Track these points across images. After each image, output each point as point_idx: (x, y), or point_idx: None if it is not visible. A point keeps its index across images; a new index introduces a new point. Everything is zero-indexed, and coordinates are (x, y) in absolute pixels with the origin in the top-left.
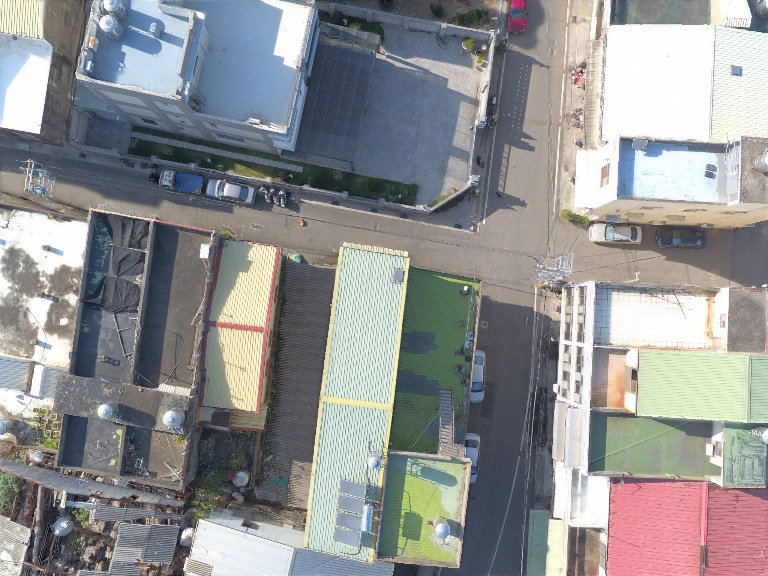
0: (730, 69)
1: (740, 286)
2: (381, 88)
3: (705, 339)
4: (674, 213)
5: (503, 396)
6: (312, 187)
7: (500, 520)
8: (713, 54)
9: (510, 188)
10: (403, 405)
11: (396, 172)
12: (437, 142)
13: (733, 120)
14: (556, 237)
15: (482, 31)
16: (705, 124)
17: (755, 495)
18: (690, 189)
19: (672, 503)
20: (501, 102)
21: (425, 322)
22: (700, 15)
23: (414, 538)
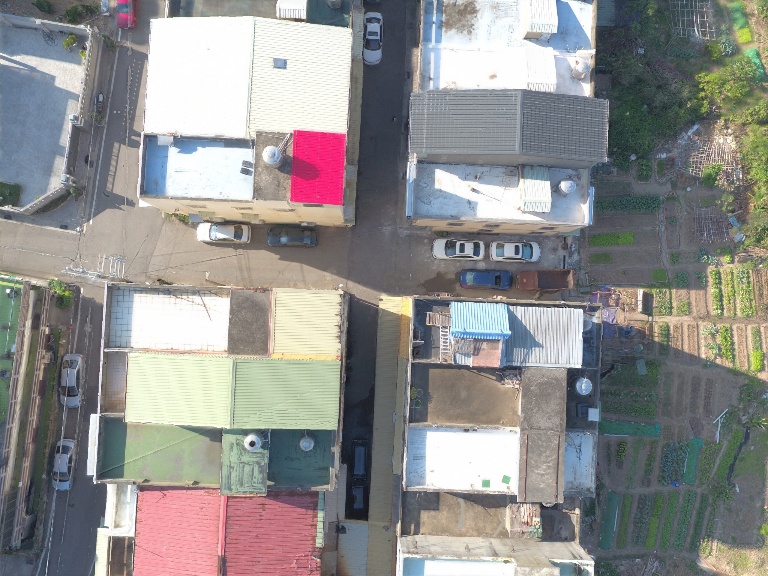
0: (272, 62)
1: (358, 286)
2: None
3: None
4: (240, 211)
5: None
6: None
7: None
8: (252, 47)
9: (118, 187)
10: None
11: None
12: (43, 141)
13: (275, 115)
14: (164, 237)
15: (78, 27)
16: (242, 119)
17: (286, 503)
18: (225, 186)
19: (193, 511)
20: (112, 99)
21: None
22: (270, 7)
23: None
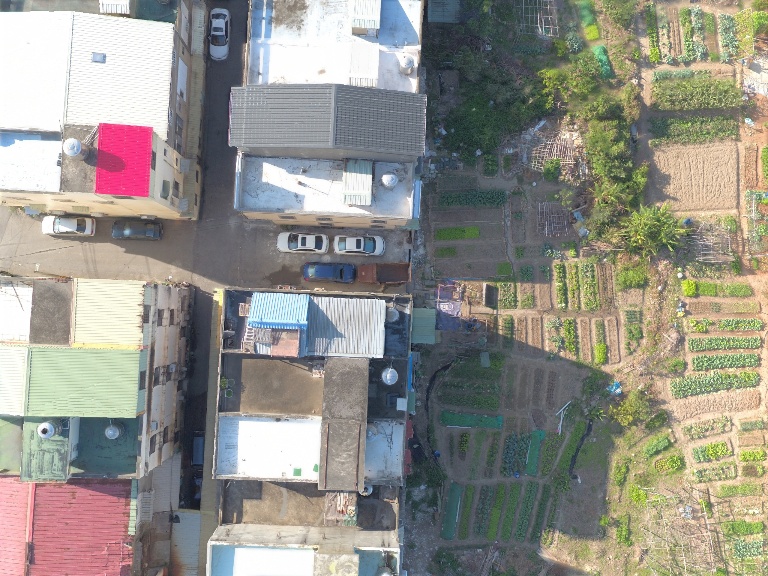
0: (91, 56)
1: (203, 278)
2: None
3: None
4: (68, 204)
5: None
6: None
7: None
8: (70, 41)
9: None
10: None
11: None
12: None
13: (94, 108)
14: (11, 230)
15: None
16: (59, 112)
17: (97, 490)
18: (42, 179)
19: (2, 499)
20: None
21: None
22: None
23: None
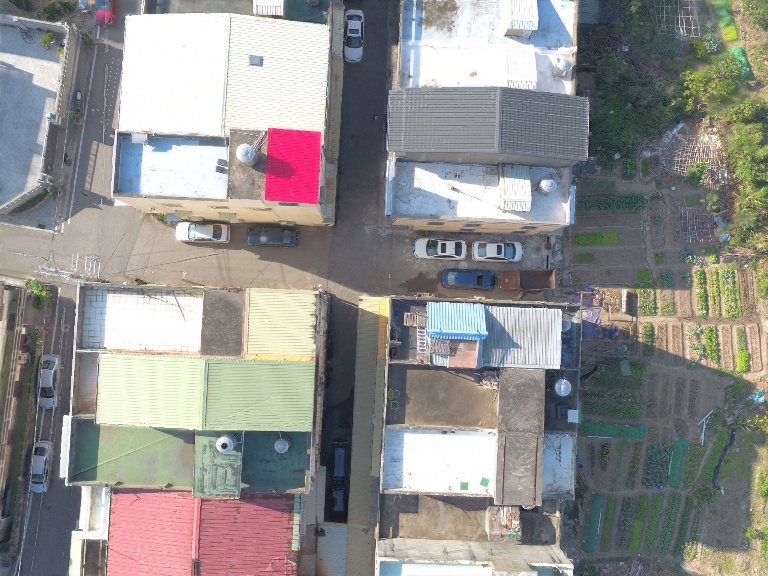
0: (248, 59)
1: (339, 286)
2: None
3: None
4: None
5: None
6: None
7: None
8: (228, 44)
9: (97, 186)
10: None
11: None
12: (20, 140)
13: (251, 112)
14: (143, 236)
15: (55, 24)
16: (217, 117)
17: (261, 505)
18: (200, 185)
19: (166, 514)
20: (91, 97)
21: None
22: (248, 3)
23: None
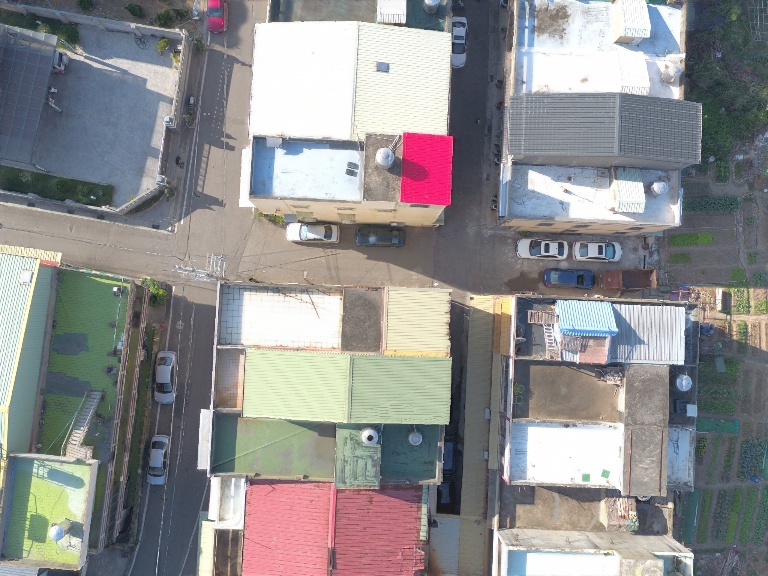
0: (375, 66)
1: (444, 285)
2: (78, 89)
3: (339, 339)
4: (338, 212)
5: (197, 397)
6: (1, 189)
7: (192, 522)
8: (356, 51)
9: (209, 188)
10: (54, 407)
11: (93, 173)
12: (135, 142)
13: (378, 117)
14: (254, 237)
15: (172, 31)
16: (347, 121)
17: (392, 496)
18: (331, 187)
19: (302, 504)
20: (202, 102)
21: (77, 323)
22: (367, 11)
23: (40, 540)
